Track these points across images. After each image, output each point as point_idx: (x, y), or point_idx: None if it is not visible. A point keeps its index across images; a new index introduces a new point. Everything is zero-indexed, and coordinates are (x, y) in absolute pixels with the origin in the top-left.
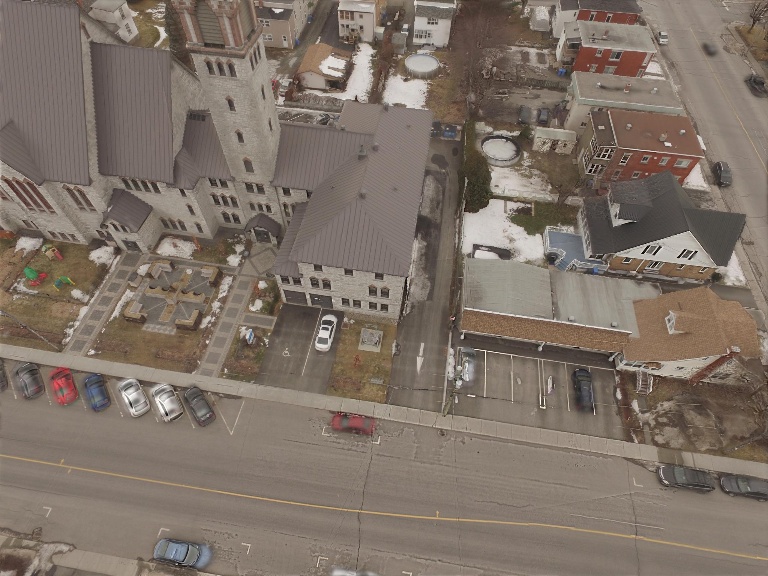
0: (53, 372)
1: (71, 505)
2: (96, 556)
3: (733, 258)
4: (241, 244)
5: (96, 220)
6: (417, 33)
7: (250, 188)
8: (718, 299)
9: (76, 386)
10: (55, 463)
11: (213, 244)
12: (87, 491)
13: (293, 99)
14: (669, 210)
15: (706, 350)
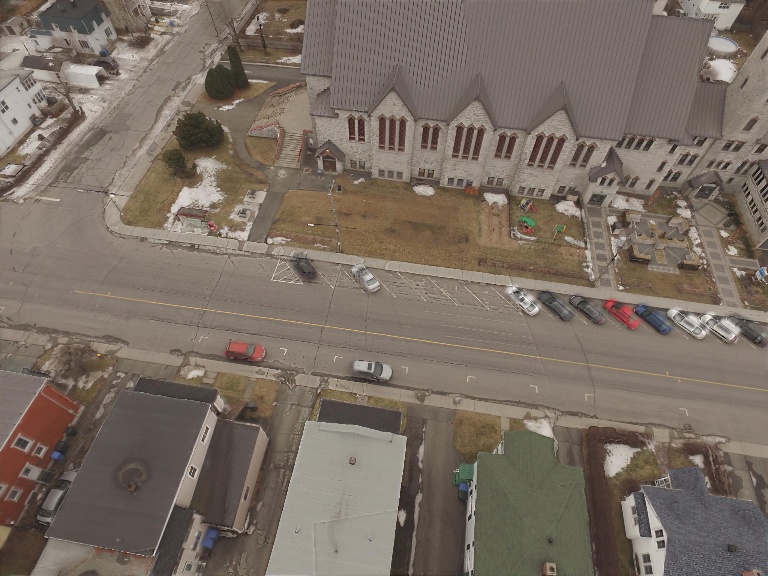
0: (600, 303)
1: (701, 407)
2: (753, 445)
3: None
4: (680, 200)
5: (574, 176)
6: (703, 17)
7: (725, 146)
8: None
9: (629, 315)
10: (663, 374)
11: (655, 200)
12: (706, 396)
13: None
14: None
15: None
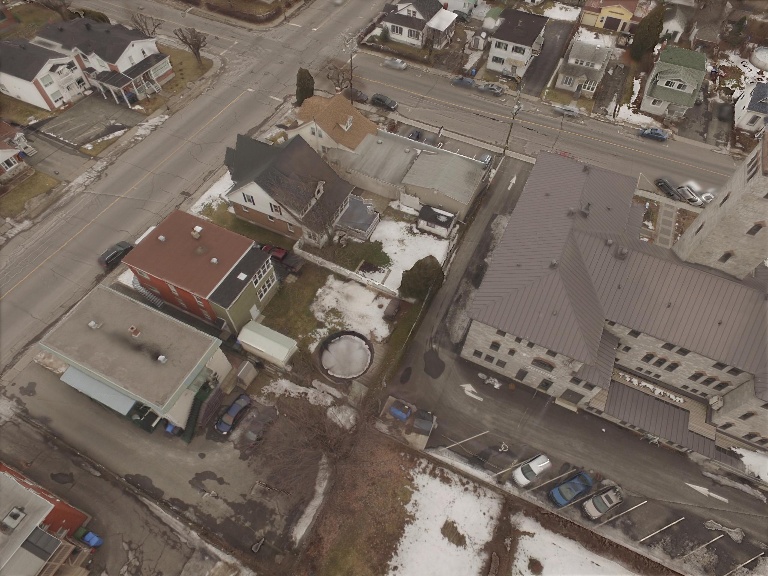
0: None
1: (724, 164)
2: (698, 145)
3: (218, 184)
4: None
5: None
6: None
7: None
8: (307, 121)
9: None
10: None
11: None
12: (719, 167)
13: (671, 571)
14: (290, 158)
15: (347, 103)
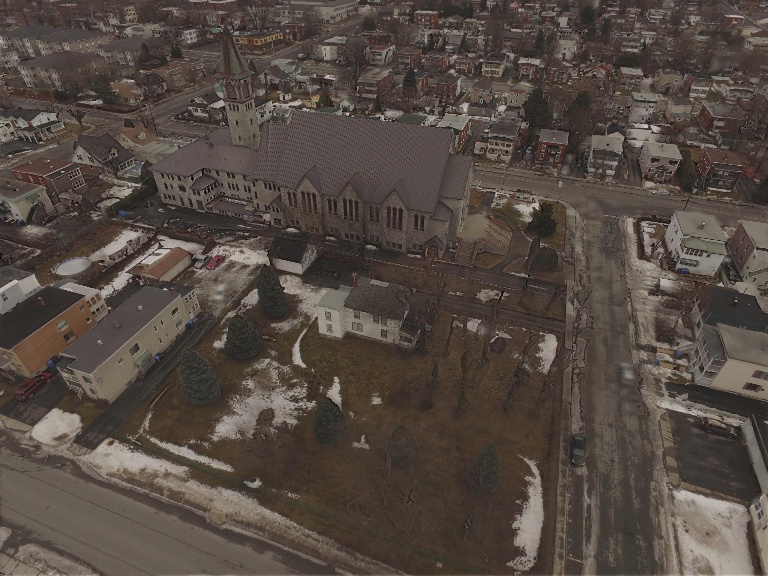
0: None
1: None
2: None
3: None
4: None
5: None
6: None
7: None
8: None
9: None
10: None
11: None
12: None
13: None
14: None
15: (144, 129)
